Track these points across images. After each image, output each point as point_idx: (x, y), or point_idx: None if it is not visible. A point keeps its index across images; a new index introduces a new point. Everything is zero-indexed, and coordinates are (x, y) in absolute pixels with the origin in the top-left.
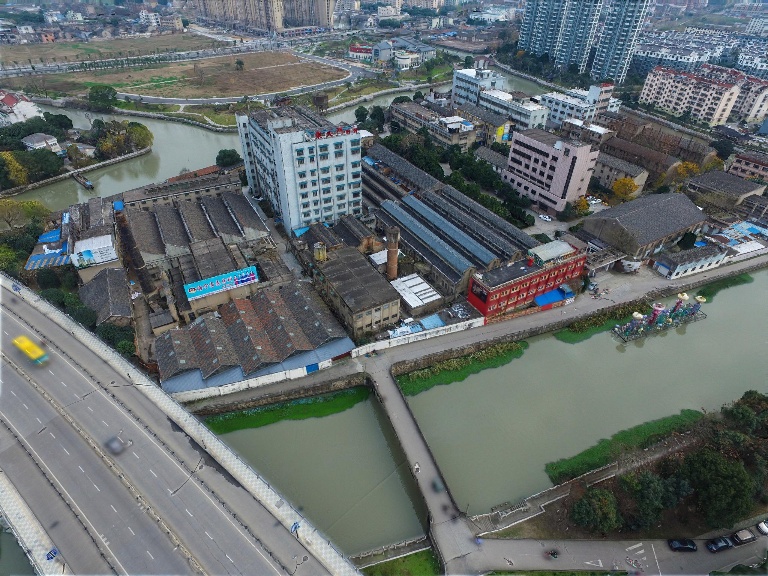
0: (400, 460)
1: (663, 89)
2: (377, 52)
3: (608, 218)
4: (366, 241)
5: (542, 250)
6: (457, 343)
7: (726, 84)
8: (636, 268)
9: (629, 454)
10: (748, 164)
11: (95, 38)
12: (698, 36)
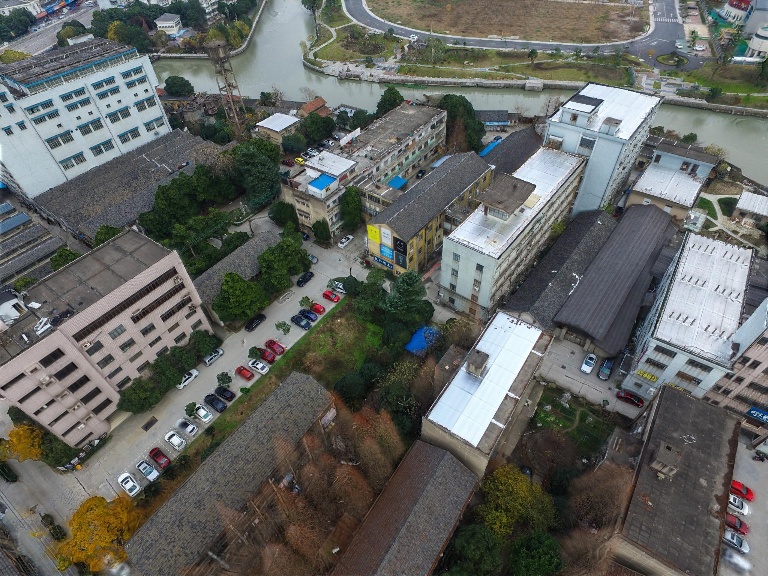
0: None
1: None
2: (750, 12)
3: None
4: None
5: None
6: None
7: None
8: None
9: None
10: None
11: None
12: None
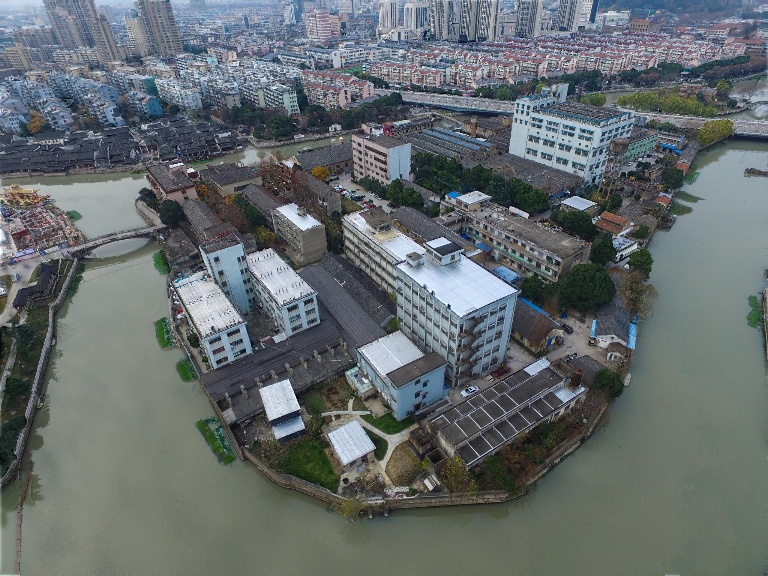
0: None
1: None
2: None
3: None
4: None
5: (405, 121)
6: None
7: None
8: None
9: (393, 110)
10: None
11: None
12: None
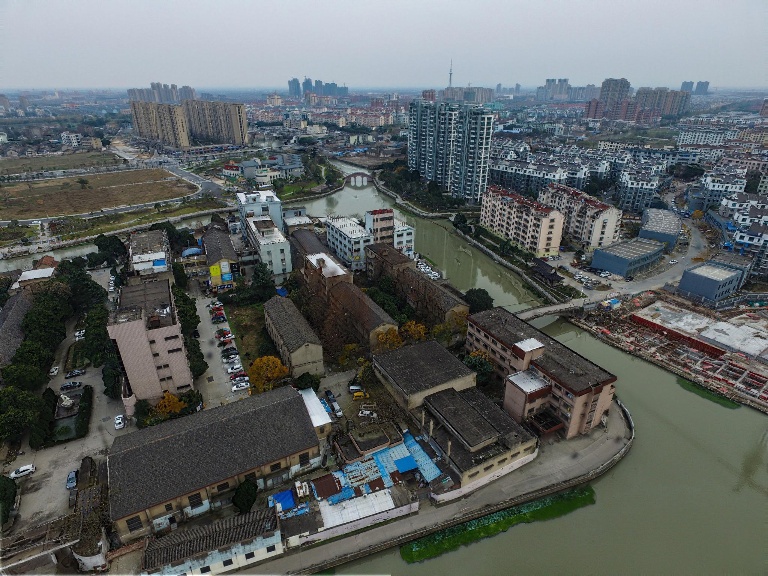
0: None
1: (495, 212)
2: (242, 170)
3: None
4: None
5: None
6: None
7: (546, 209)
8: (97, 564)
9: None
10: (479, 331)
11: None
12: (592, 151)
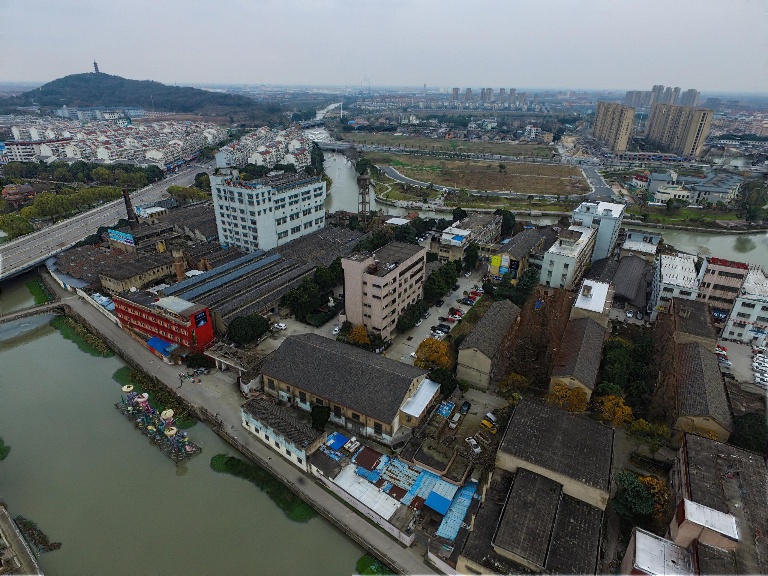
0: (5, 342)
1: None
2: (650, 182)
3: (293, 335)
4: (203, 261)
5: (171, 299)
6: (97, 323)
7: None
8: (244, 391)
9: None
10: None
11: (475, 140)
12: None
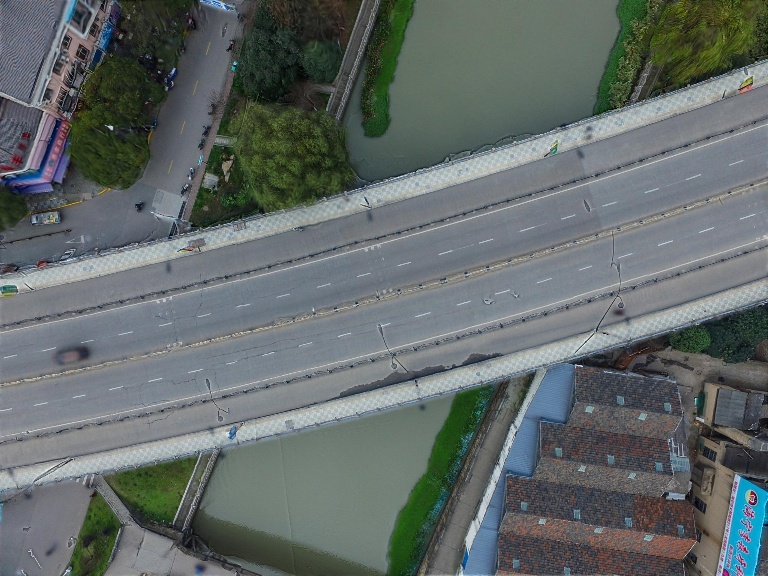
0: (299, 553)
1: None
2: None
3: None
4: None
5: None
6: None
7: None
8: None
9: None
10: None
11: None
12: None
